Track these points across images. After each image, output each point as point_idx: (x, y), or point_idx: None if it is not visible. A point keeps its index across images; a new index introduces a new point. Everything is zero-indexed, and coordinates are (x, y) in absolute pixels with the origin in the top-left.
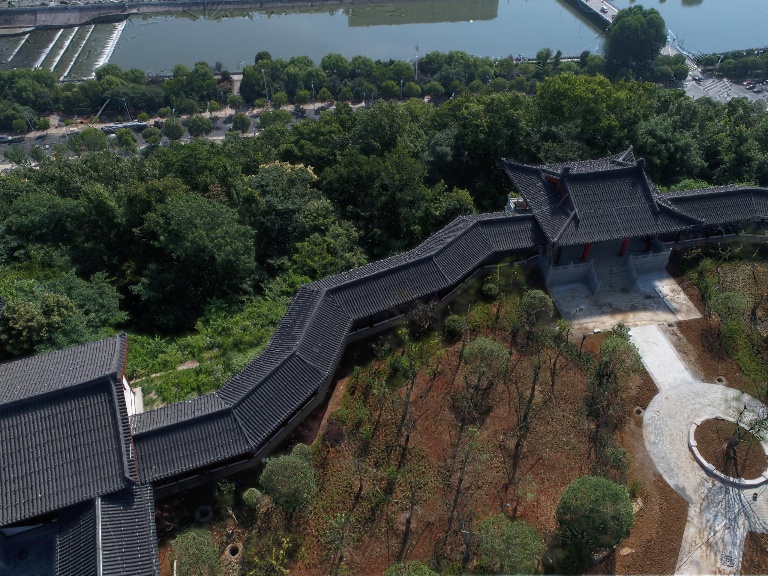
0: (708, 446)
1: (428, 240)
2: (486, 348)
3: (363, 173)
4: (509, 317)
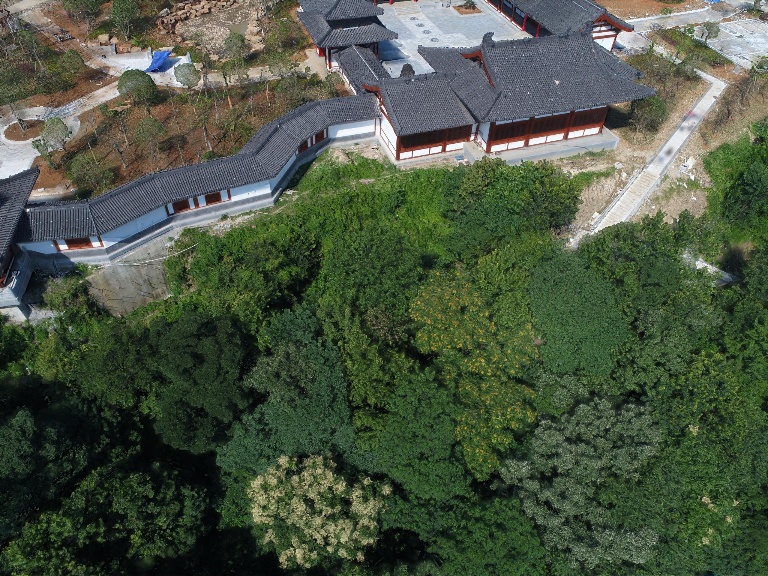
0: (39, 130)
1: (146, 210)
2: (151, 118)
3: (180, 318)
4: (112, 173)
